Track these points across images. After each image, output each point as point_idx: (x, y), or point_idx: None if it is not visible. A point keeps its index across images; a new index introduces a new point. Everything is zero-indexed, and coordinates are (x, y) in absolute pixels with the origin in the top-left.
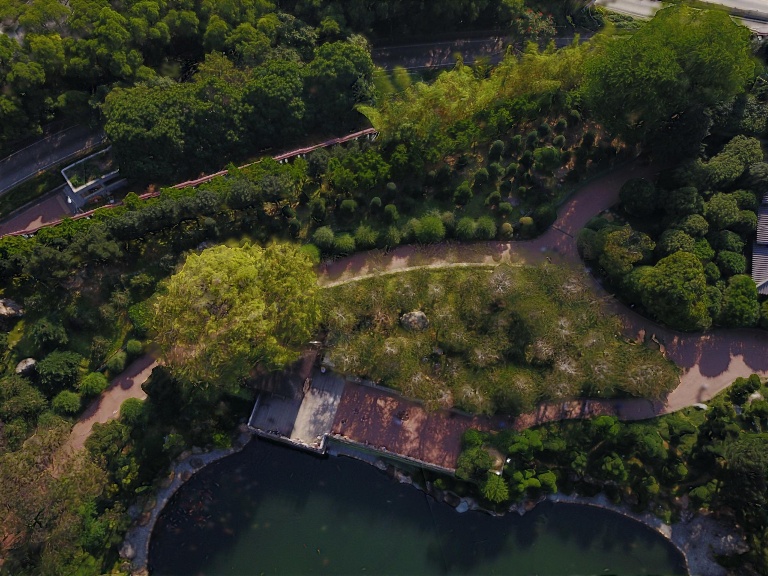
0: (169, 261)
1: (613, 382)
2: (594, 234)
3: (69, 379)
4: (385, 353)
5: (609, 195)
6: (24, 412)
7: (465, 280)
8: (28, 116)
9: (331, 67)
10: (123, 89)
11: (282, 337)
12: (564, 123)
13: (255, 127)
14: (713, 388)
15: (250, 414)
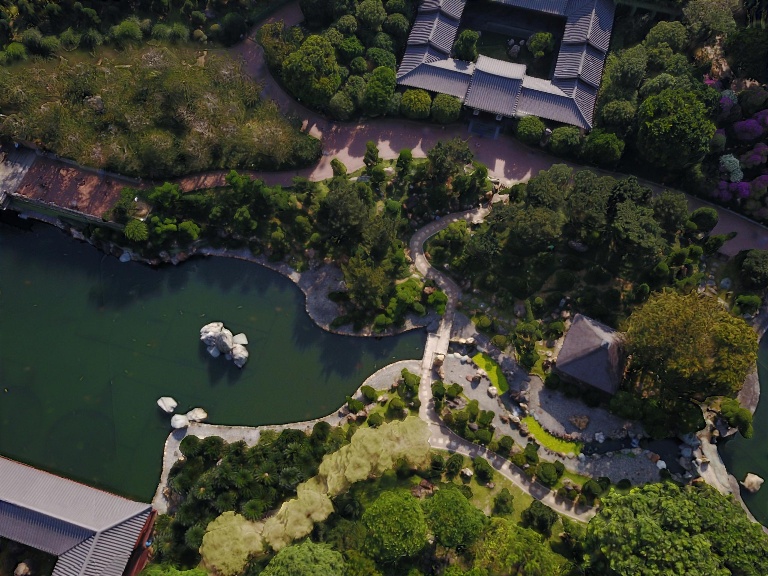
0: None
1: (239, 141)
2: None
3: None
4: (41, 112)
5: None
6: None
7: None
8: None
9: None
10: None
11: None
12: None
13: None
14: (356, 165)
15: None
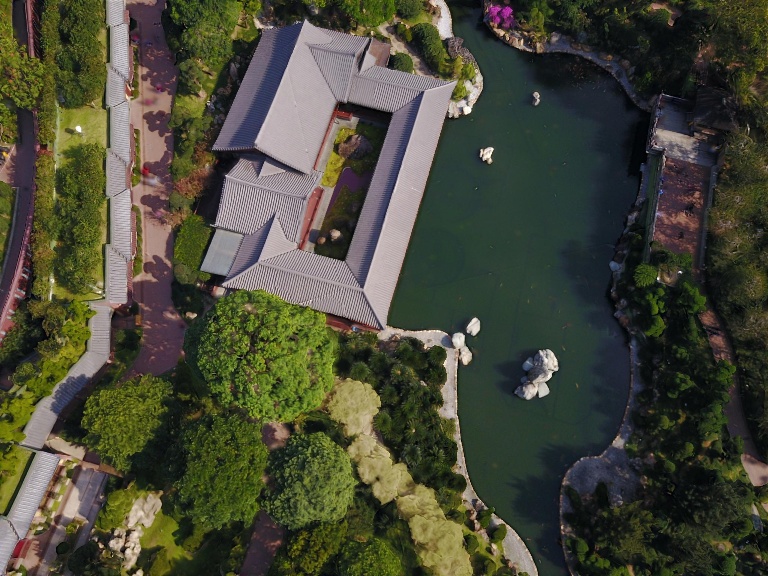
0: None
1: None
2: None
3: None
4: (761, 166)
5: None
6: None
7: None
8: None
9: None
10: None
11: (765, 76)
12: None
13: None
14: None
15: None
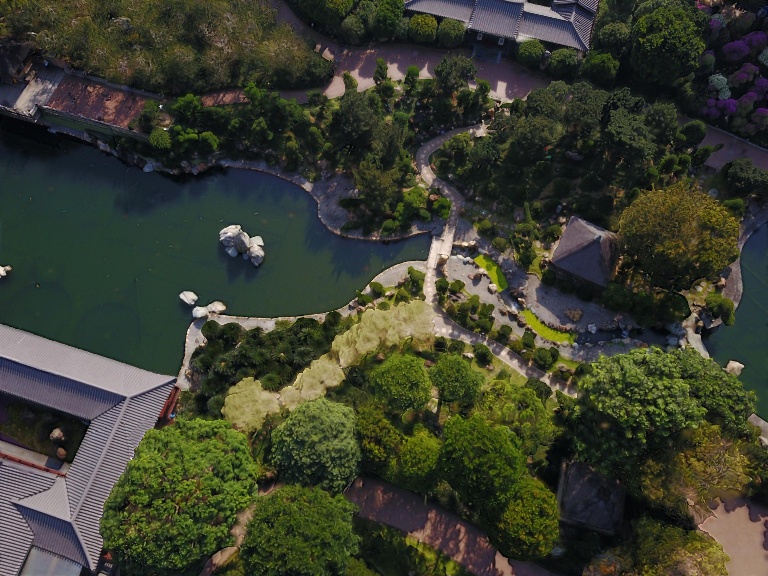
0: None
1: (257, 56)
2: None
3: None
4: (71, 26)
5: None
6: None
7: None
8: None
9: None
10: None
11: None
12: None
13: None
14: (366, 85)
15: None
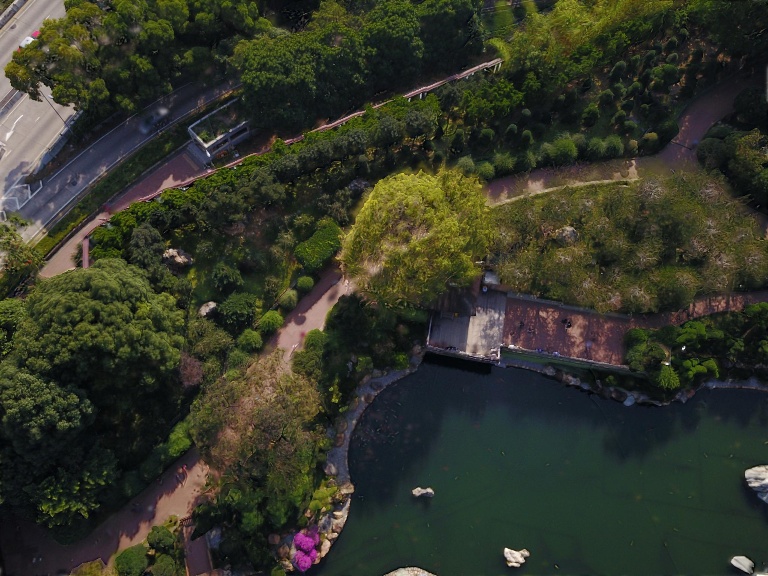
0: (326, 200)
1: (766, 271)
2: (720, 142)
3: (250, 318)
4: (559, 262)
5: (719, 108)
6: (215, 352)
7: (614, 192)
8: (159, 74)
9: (448, 4)
10: (249, 41)
11: (470, 253)
12: (676, 41)
13: (378, 69)
14: None
15: (427, 334)
